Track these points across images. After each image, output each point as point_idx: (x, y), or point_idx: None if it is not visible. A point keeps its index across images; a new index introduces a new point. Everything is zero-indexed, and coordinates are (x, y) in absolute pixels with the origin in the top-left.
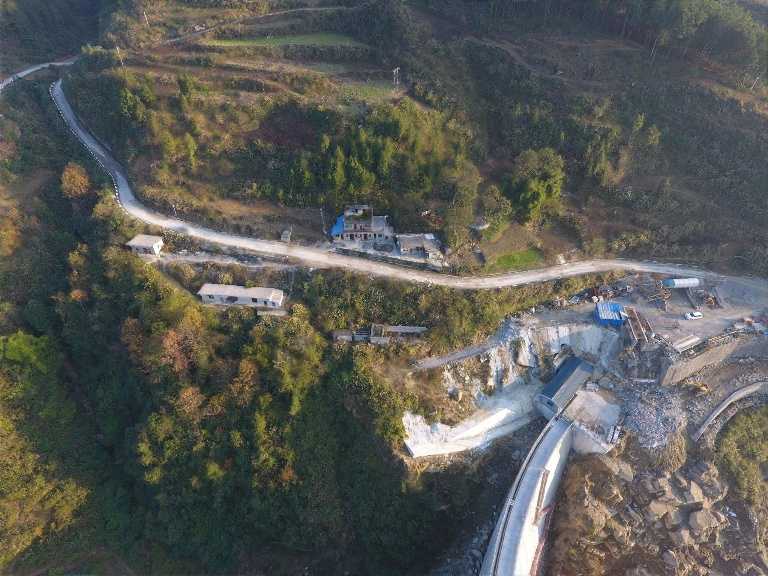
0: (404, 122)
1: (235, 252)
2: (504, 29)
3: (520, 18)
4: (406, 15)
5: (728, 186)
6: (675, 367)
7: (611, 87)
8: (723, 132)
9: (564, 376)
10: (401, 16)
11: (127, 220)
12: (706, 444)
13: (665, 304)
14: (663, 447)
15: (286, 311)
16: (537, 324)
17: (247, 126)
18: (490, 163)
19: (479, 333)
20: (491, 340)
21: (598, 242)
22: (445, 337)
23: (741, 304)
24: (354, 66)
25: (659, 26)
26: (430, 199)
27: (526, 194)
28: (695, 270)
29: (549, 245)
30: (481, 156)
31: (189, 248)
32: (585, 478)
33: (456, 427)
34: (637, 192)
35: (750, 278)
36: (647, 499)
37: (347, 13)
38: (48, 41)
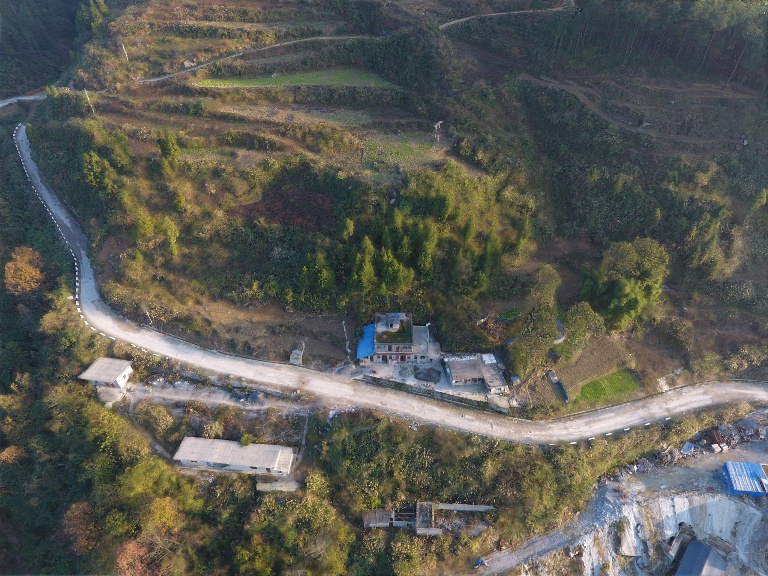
0: (450, 195)
1: (228, 384)
2: (570, 67)
3: (591, 53)
4: (447, 50)
5: None
6: None
7: (716, 145)
8: None
9: None
10: (441, 51)
11: (85, 336)
12: None
13: None
14: None
15: (297, 482)
16: (643, 493)
17: (246, 197)
18: (561, 247)
19: (565, 510)
20: (582, 520)
21: (711, 360)
22: (520, 521)
23: None
24: (381, 113)
25: None
26: (489, 306)
27: (620, 302)
28: None
29: (645, 364)
30: (547, 235)
31: (167, 375)
32: None
33: None
34: (758, 289)
35: None
36: None
37: (371, 44)
38: (18, 71)
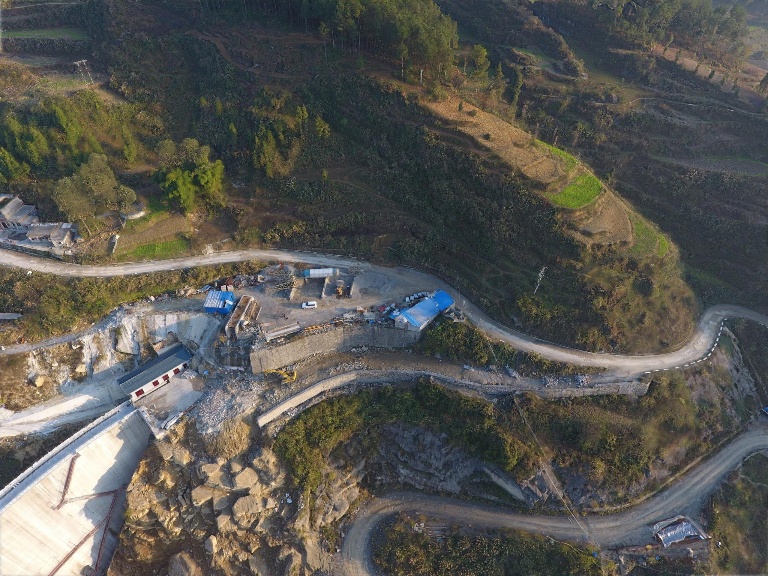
0: (75, 113)
1: None
2: (215, 23)
3: (231, 12)
4: (115, 8)
5: (392, 178)
6: (257, 355)
7: (297, 80)
8: (390, 124)
9: (153, 363)
10: (110, 9)
11: None
12: (266, 431)
13: (290, 293)
14: (217, 433)
15: None
16: (147, 312)
17: None
18: None
19: (80, 320)
20: (93, 327)
21: (251, 232)
22: (38, 324)
23: (373, 294)
24: (69, 59)
25: (324, 18)
26: None
27: (164, 184)
28: (350, 261)
29: (202, 235)
30: None
31: None
32: (140, 463)
33: (20, 412)
34: (302, 183)
35: (402, 269)
36: (195, 485)
37: None
38: None
